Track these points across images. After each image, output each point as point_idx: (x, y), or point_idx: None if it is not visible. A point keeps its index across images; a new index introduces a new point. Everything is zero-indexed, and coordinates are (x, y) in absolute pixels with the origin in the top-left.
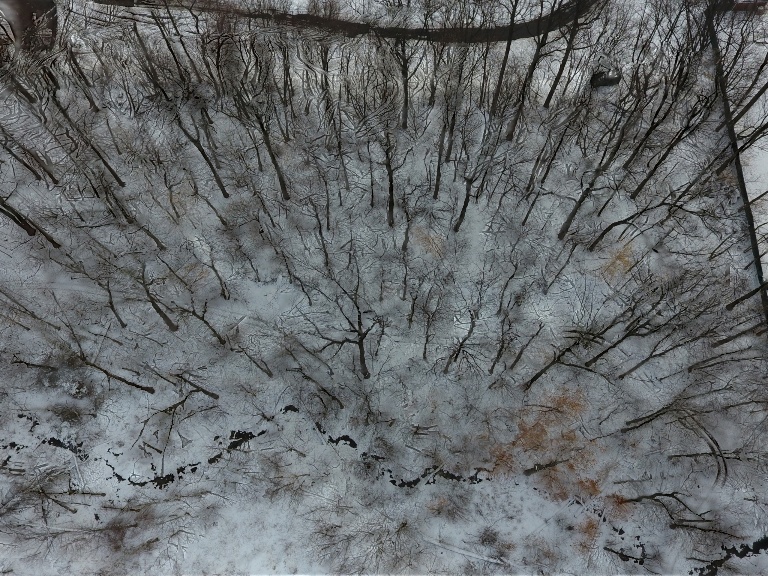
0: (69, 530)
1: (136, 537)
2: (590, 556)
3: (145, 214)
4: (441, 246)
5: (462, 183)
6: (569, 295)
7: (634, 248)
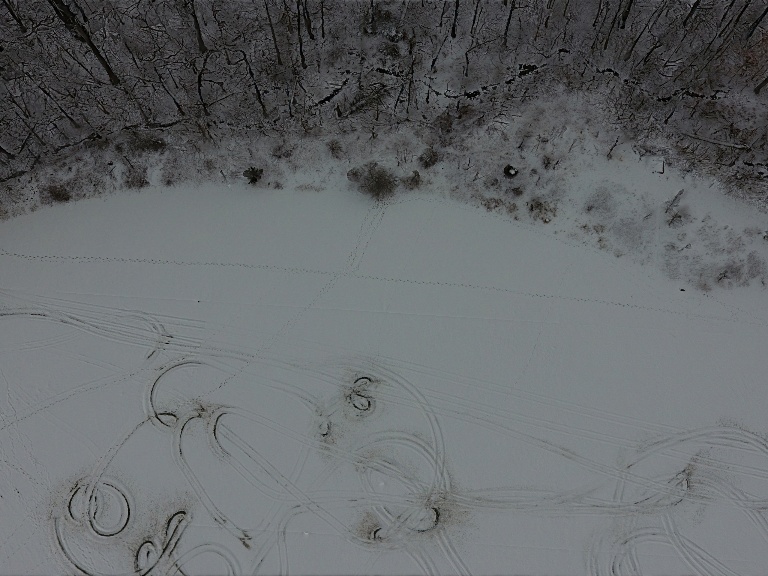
0: (409, 119)
1: (463, 123)
2: None
3: None
4: None
5: None
6: None
7: None
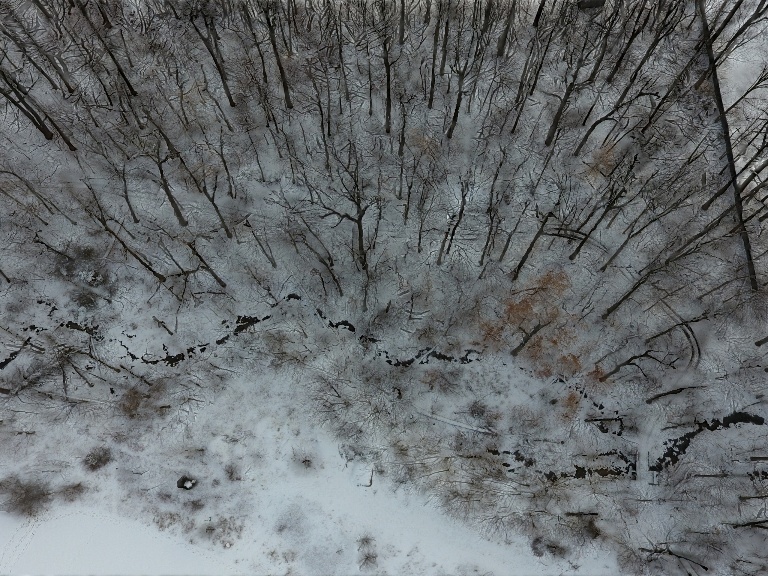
0: (87, 400)
1: (149, 406)
2: (572, 427)
3: (156, 120)
4: (435, 151)
5: (455, 93)
6: (555, 196)
7: (616, 154)
